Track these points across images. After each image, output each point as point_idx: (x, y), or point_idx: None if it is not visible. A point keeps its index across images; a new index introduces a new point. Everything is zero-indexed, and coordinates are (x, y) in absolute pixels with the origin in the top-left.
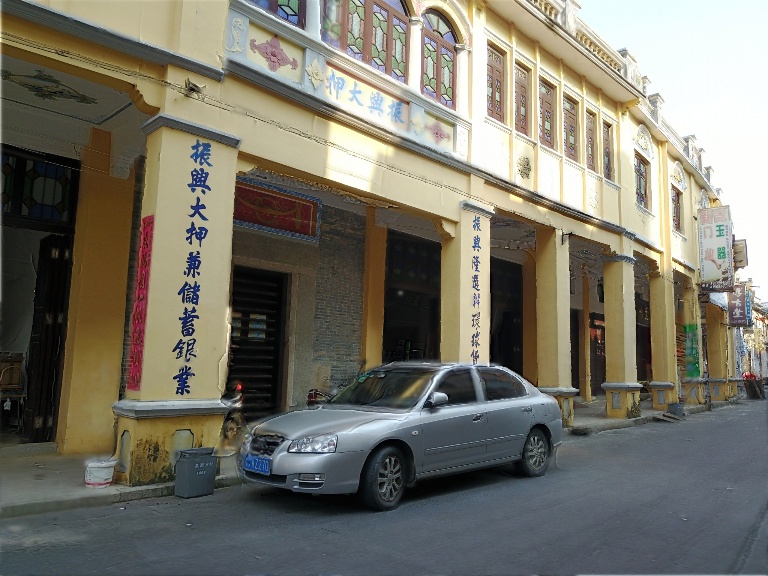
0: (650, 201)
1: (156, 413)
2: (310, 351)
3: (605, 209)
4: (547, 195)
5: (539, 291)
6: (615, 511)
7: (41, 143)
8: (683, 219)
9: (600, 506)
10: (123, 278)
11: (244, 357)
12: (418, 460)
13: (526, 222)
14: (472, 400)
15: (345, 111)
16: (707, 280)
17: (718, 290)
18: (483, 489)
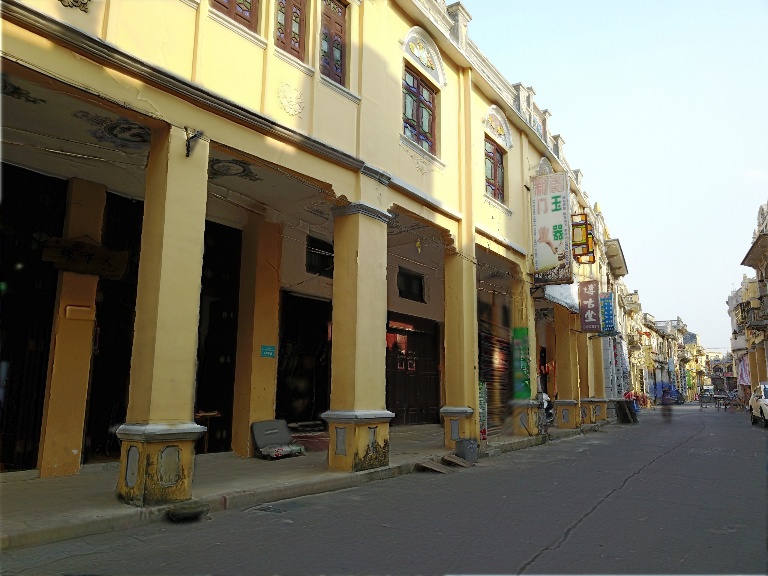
0: (438, 143)
1: None
2: None
3: (323, 125)
4: (147, 58)
5: (143, 242)
6: None
7: None
8: (507, 186)
9: None
10: None
11: None
12: None
13: (130, 117)
14: None
15: None
16: (541, 268)
17: (553, 281)
18: None
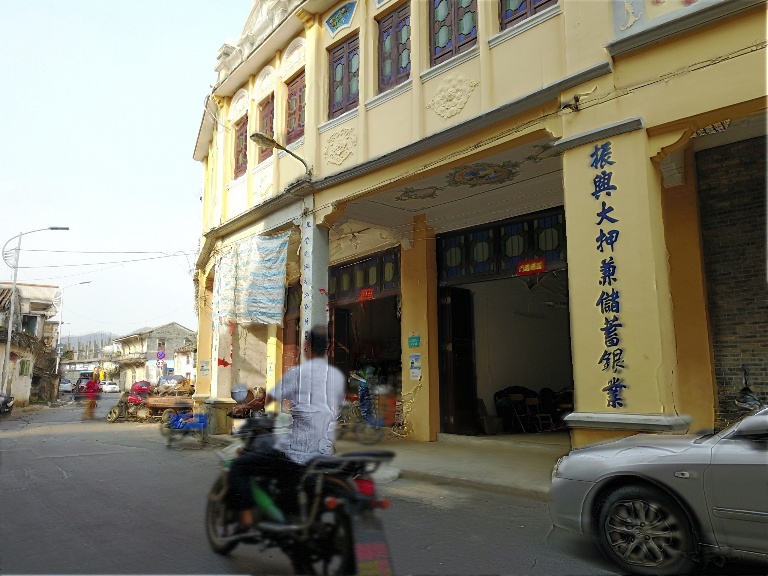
0: None
1: (582, 424)
2: None
3: None
4: None
5: None
6: None
7: None
8: None
9: None
10: (698, 286)
11: None
12: (695, 520)
13: None
14: None
15: None
16: None
17: None
18: None
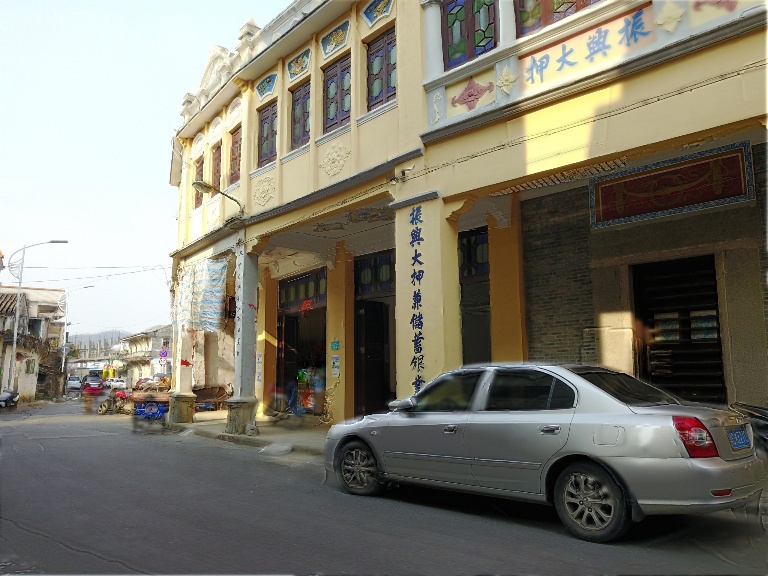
0: None
1: None
2: (762, 350)
3: None
4: None
5: None
6: (343, 547)
7: (474, 222)
8: None
9: (372, 545)
10: (517, 305)
11: (683, 363)
12: (378, 459)
13: None
14: (458, 408)
15: (527, 98)
16: None
17: None
18: (447, 513)
